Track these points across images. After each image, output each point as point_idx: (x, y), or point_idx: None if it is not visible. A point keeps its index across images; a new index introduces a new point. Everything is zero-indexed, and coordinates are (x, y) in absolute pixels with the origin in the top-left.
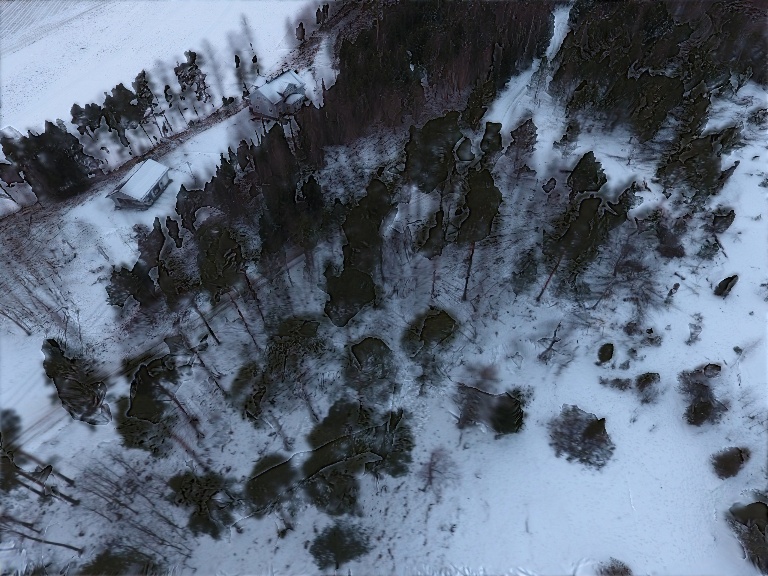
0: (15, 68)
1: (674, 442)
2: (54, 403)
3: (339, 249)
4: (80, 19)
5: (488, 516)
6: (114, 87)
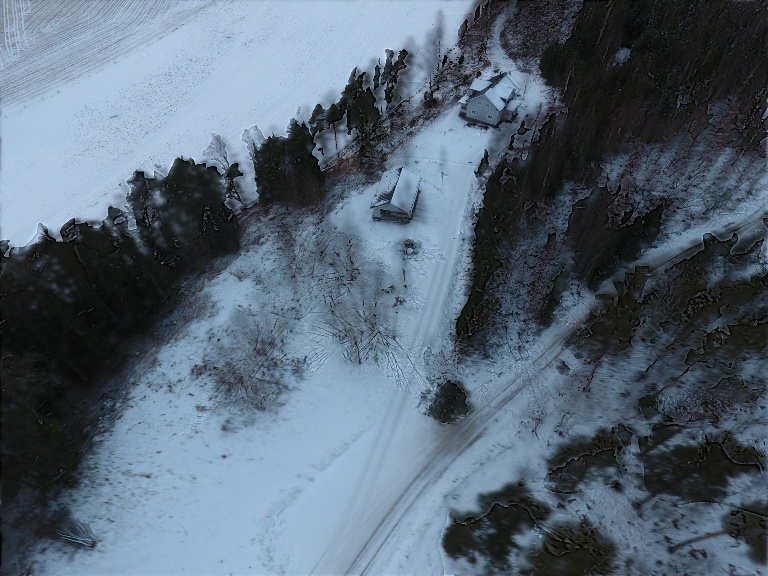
0: (167, 55)
1: None
2: (430, 447)
3: (712, 291)
4: (215, 6)
5: None
6: (276, 80)
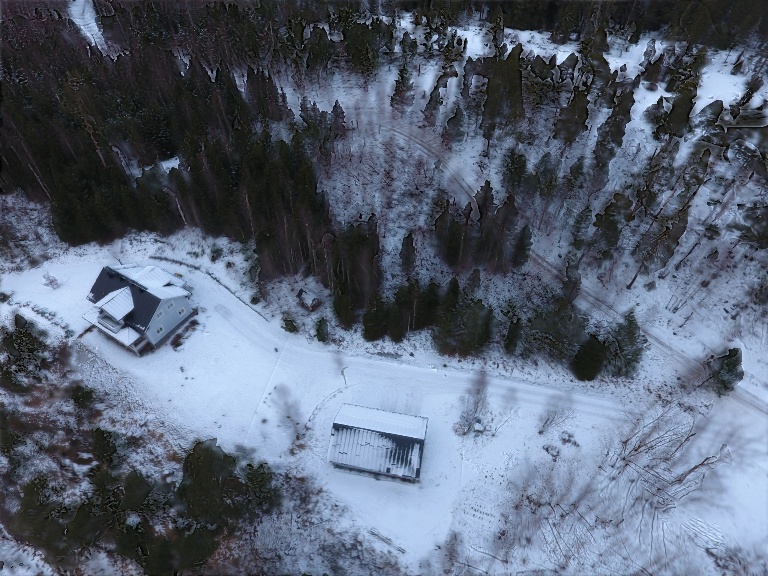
0: None
1: (646, 95)
2: (737, 404)
3: None
4: None
5: (708, 146)
6: None
